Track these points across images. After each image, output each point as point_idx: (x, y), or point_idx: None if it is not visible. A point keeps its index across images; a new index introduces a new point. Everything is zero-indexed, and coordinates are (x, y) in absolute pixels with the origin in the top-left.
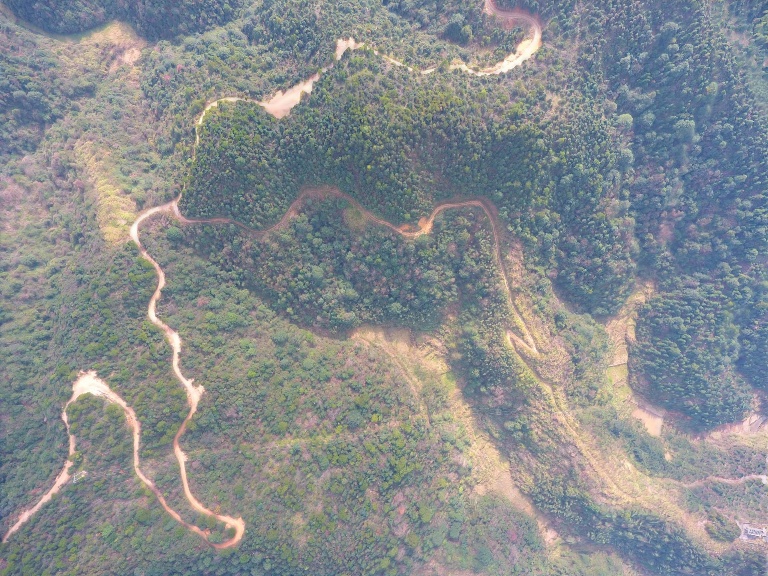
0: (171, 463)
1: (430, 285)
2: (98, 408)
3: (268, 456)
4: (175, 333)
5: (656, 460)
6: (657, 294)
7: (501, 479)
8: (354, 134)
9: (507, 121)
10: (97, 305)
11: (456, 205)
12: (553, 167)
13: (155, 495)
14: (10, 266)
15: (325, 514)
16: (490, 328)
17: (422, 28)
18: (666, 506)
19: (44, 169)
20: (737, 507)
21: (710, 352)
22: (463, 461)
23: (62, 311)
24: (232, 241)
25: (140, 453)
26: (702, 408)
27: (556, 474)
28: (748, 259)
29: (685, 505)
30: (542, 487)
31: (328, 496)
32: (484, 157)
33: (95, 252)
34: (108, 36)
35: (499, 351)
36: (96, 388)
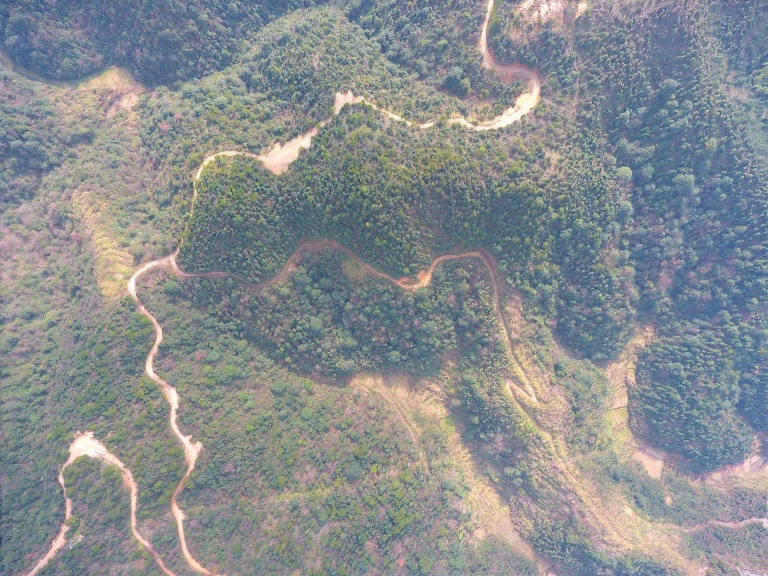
0: (169, 522)
1: (429, 335)
2: (95, 471)
3: (266, 512)
4: (173, 389)
5: (657, 505)
6: (657, 338)
7: (501, 523)
8: (352, 193)
9: (506, 179)
10: (94, 363)
11: (455, 256)
12: (552, 222)
13: (152, 556)
14: (7, 319)
15: (324, 570)
16: (489, 377)
17: (421, 78)
18: (667, 553)
19: (41, 217)
20: (738, 553)
21: (710, 398)
22: (463, 508)
23: (59, 368)
24: (230, 294)
25: (137, 514)
26: (702, 452)
27: (556, 520)
28: (748, 308)
29: (686, 552)
30: (542, 532)
31: (327, 551)
32: (483, 213)
33: (92, 307)
34: (106, 82)
35: (499, 400)
36: (93, 449)
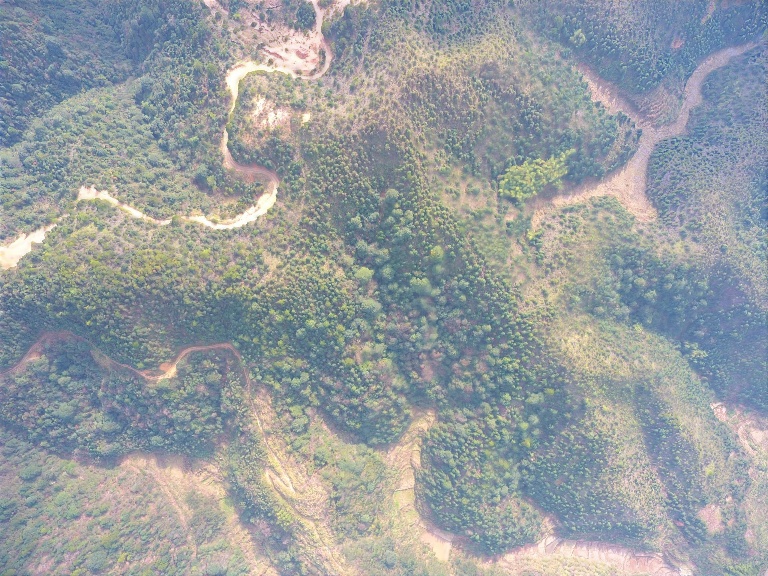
0: None
1: (184, 423)
2: None
3: None
4: None
5: None
6: (436, 423)
7: None
8: (66, 295)
9: (223, 284)
10: None
11: (204, 348)
12: (284, 322)
13: None
14: None
15: None
16: (248, 465)
17: (182, 169)
18: None
19: None
20: None
21: (479, 487)
22: None
23: None
24: None
25: None
26: (484, 536)
27: None
28: (501, 403)
29: None
30: None
31: None
32: (212, 312)
33: None
34: None
35: (255, 489)
36: None
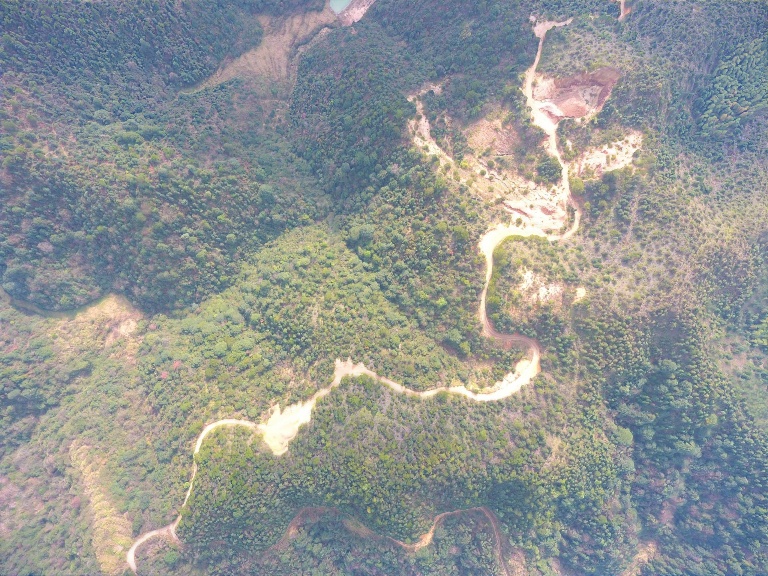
0: None
1: None
2: None
3: None
4: None
5: None
6: (660, 556)
7: None
8: (353, 488)
9: (507, 469)
10: None
11: (457, 511)
12: None
13: None
14: None
15: None
16: None
17: (420, 327)
18: None
19: (39, 459)
20: None
21: None
22: None
23: None
24: (231, 559)
25: None
26: None
27: None
28: (751, 550)
29: None
30: None
31: None
32: (485, 489)
33: None
34: (104, 310)
35: None
36: None
